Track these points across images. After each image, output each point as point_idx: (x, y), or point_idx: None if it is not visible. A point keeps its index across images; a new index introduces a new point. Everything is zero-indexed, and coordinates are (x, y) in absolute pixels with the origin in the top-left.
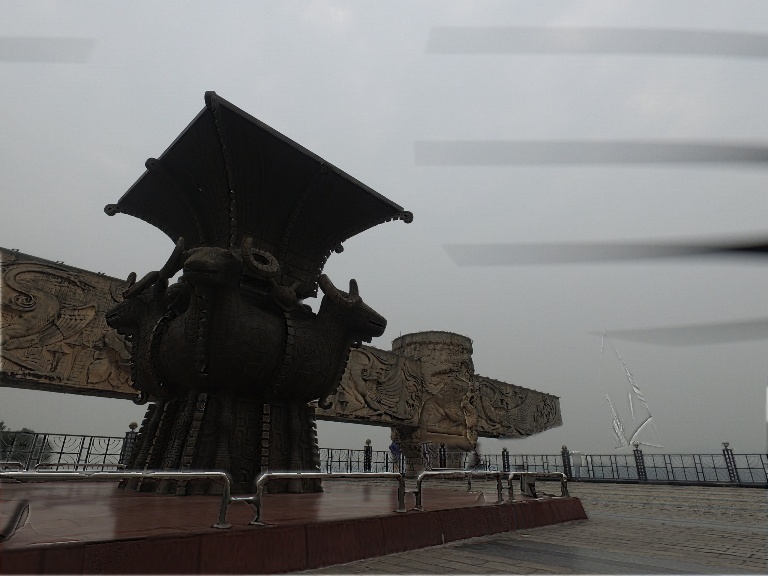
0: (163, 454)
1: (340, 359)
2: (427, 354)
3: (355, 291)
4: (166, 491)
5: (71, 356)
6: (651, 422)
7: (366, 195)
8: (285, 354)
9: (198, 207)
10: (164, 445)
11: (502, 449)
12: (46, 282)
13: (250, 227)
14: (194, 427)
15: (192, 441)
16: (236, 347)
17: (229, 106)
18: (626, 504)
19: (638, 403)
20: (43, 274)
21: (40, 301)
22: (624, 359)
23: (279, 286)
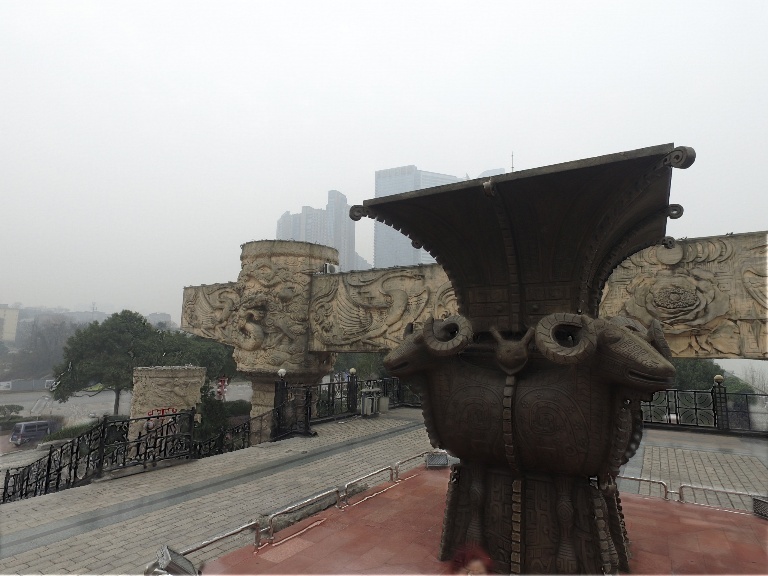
0: None
1: (611, 425)
2: None
3: (586, 333)
4: None
5: None
6: None
7: (580, 172)
8: (504, 431)
9: None
10: None
11: None
12: None
13: (473, 279)
14: None
15: (446, 511)
16: (454, 426)
17: (376, 201)
18: None
19: None
20: None
21: None
22: None
23: (500, 344)
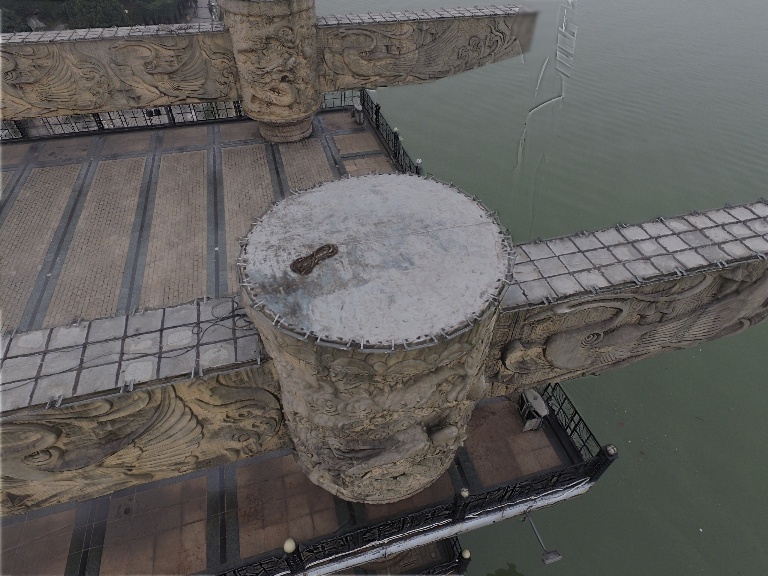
0: None
1: None
2: (231, 25)
3: None
4: None
5: None
6: (555, 103)
7: None
8: None
9: None
10: None
11: (375, 103)
12: None
13: None
14: None
15: None
16: None
17: None
18: (6, 326)
19: (551, 75)
20: None
21: None
22: (572, 0)
23: None
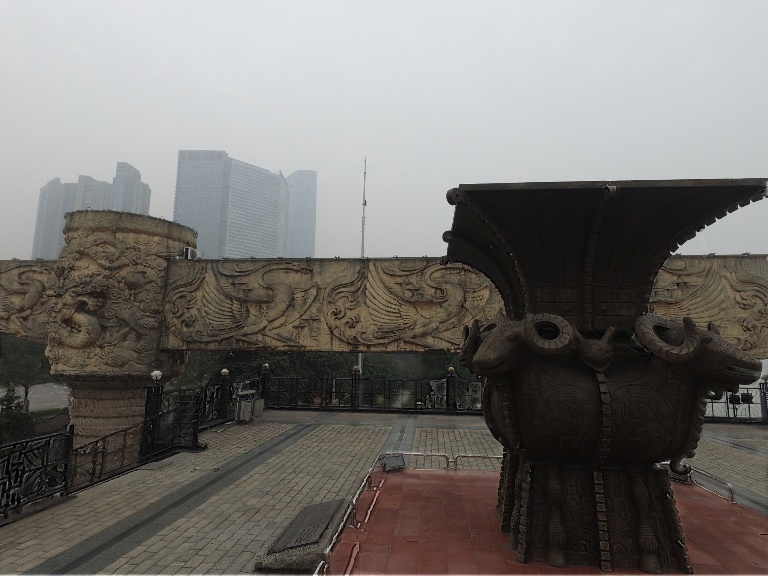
0: (514, 501)
1: (691, 414)
2: None
3: (692, 333)
4: (514, 547)
5: None
6: None
7: (689, 190)
8: (603, 426)
9: (496, 260)
10: (514, 493)
11: None
12: (450, 275)
13: (543, 278)
14: (523, 498)
15: (523, 512)
16: (545, 424)
17: (475, 187)
18: None
19: None
20: (446, 269)
21: (450, 292)
22: None
23: (585, 343)
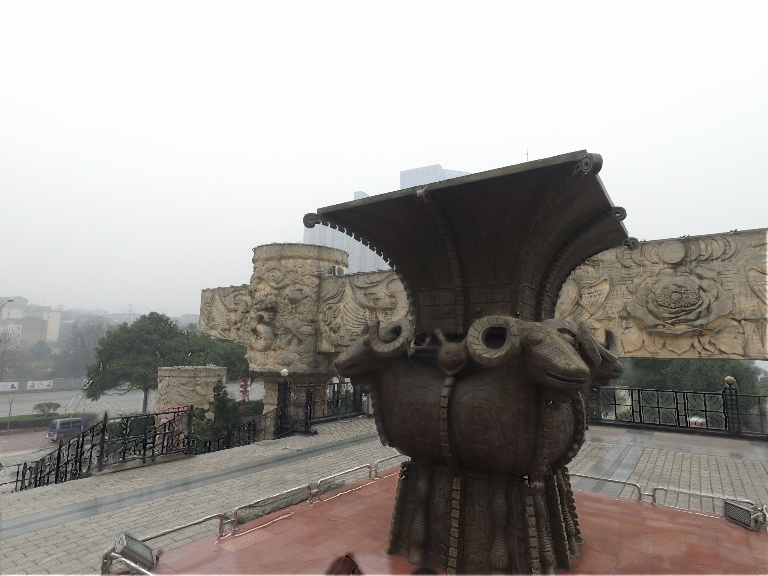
0: None
1: (538, 425)
2: None
3: (509, 335)
4: None
5: (602, 330)
6: None
7: (505, 179)
8: (440, 430)
9: None
10: None
11: None
12: None
13: (423, 283)
14: None
15: None
16: (400, 425)
17: (328, 209)
18: None
19: None
20: None
21: None
22: None
23: (442, 346)
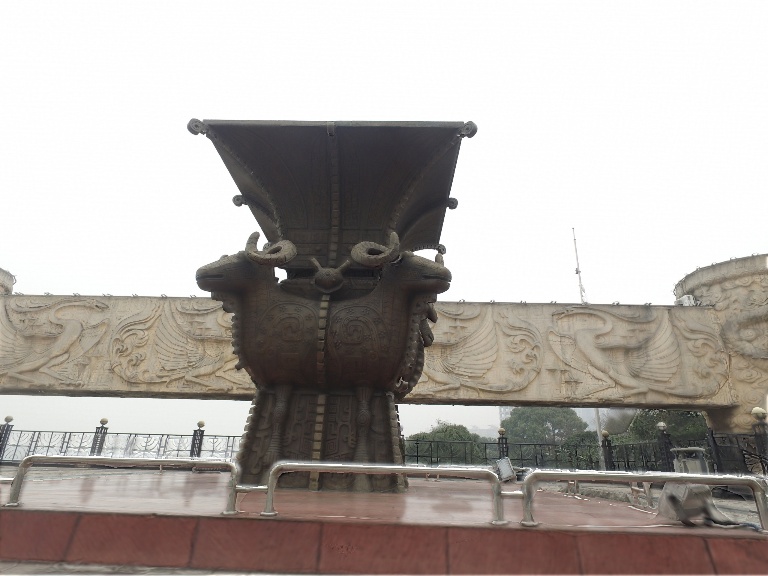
0: None
1: None
2: None
3: None
4: None
5: None
6: None
7: None
8: None
9: None
10: None
11: None
12: None
13: None
14: None
15: None
16: None
17: None
18: None
19: None
20: None
21: None
22: None
23: None
